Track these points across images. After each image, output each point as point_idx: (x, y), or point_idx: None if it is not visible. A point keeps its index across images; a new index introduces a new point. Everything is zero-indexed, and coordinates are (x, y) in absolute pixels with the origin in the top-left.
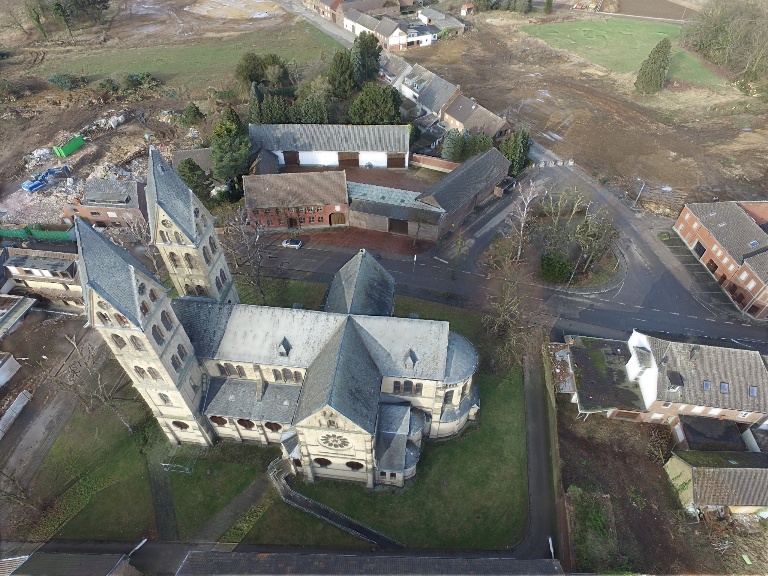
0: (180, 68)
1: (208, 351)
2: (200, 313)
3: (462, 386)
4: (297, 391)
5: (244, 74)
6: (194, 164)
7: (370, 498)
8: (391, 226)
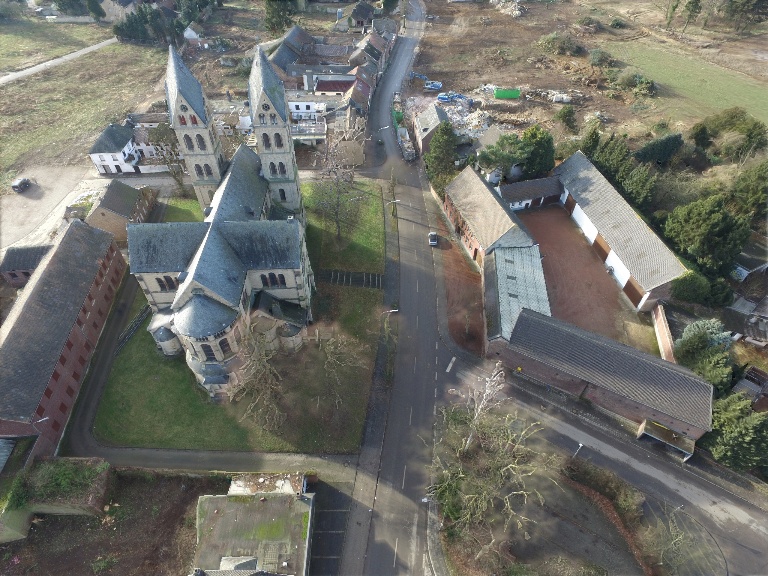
0: (699, 95)
1: None
2: None
3: None
4: None
5: (699, 123)
6: (449, 129)
7: None
8: None
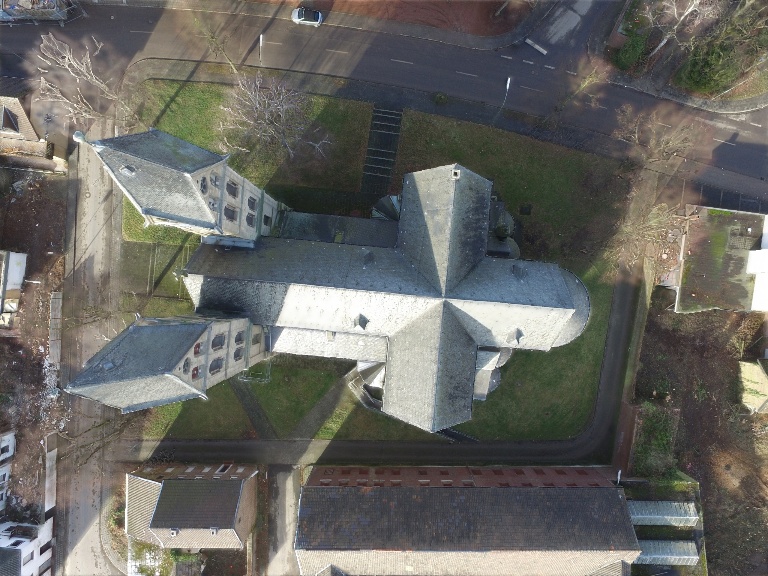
0: None
1: (266, 319)
2: (246, 290)
3: None
4: None
5: None
6: None
7: None
8: None
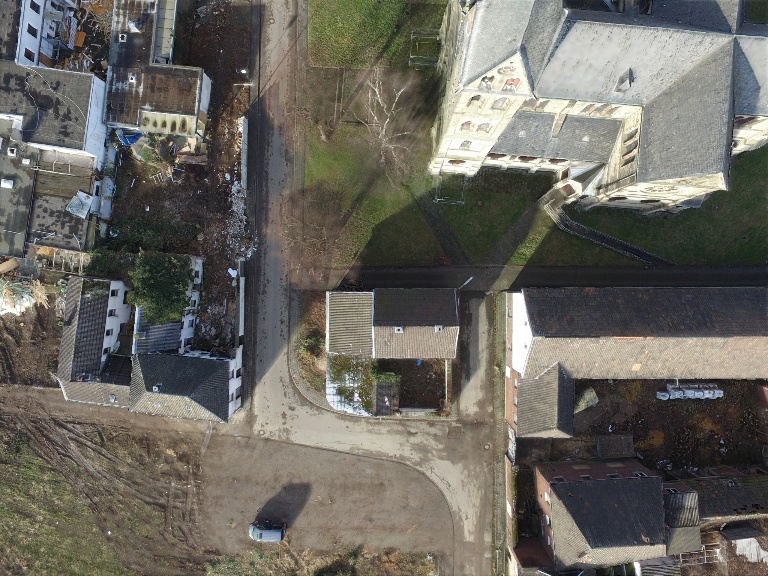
0: None
1: None
2: None
3: None
4: (600, 125)
5: None
6: None
7: (643, 224)
8: None
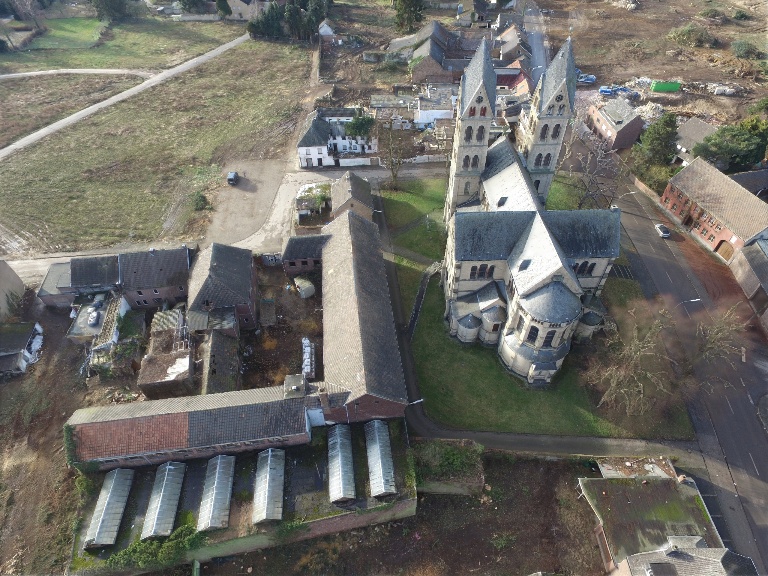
0: None
1: (486, 177)
2: (504, 155)
3: (530, 323)
4: None
5: None
6: (673, 121)
7: (438, 319)
8: (757, 296)
